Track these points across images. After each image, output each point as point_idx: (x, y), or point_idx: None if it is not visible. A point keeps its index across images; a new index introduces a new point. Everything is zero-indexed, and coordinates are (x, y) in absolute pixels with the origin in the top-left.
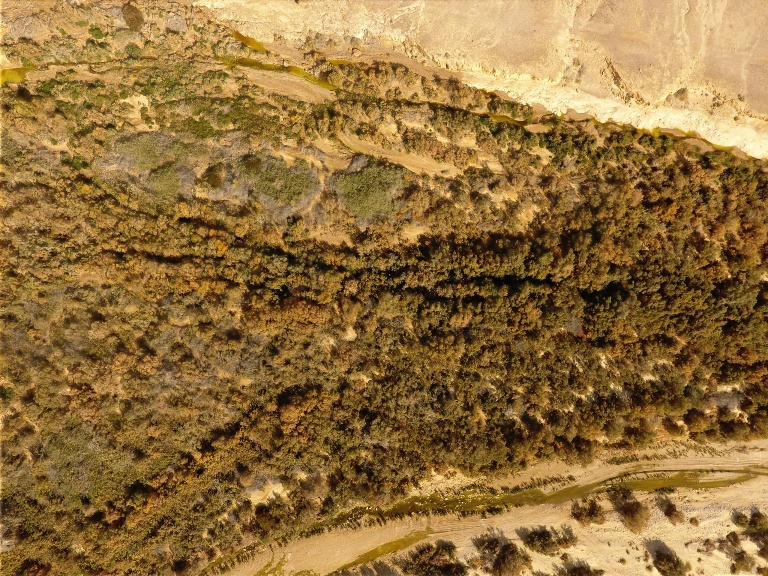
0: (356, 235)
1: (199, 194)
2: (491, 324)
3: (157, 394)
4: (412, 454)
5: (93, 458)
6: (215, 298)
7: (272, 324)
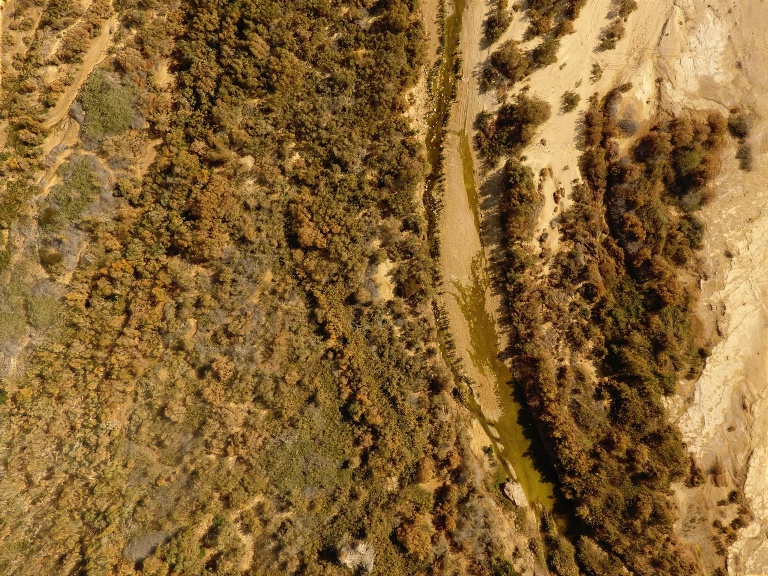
0: (151, 133)
1: (66, 280)
2: (269, 16)
3: (257, 368)
4: (379, 128)
5: (304, 447)
6: (177, 289)
7: (213, 232)
